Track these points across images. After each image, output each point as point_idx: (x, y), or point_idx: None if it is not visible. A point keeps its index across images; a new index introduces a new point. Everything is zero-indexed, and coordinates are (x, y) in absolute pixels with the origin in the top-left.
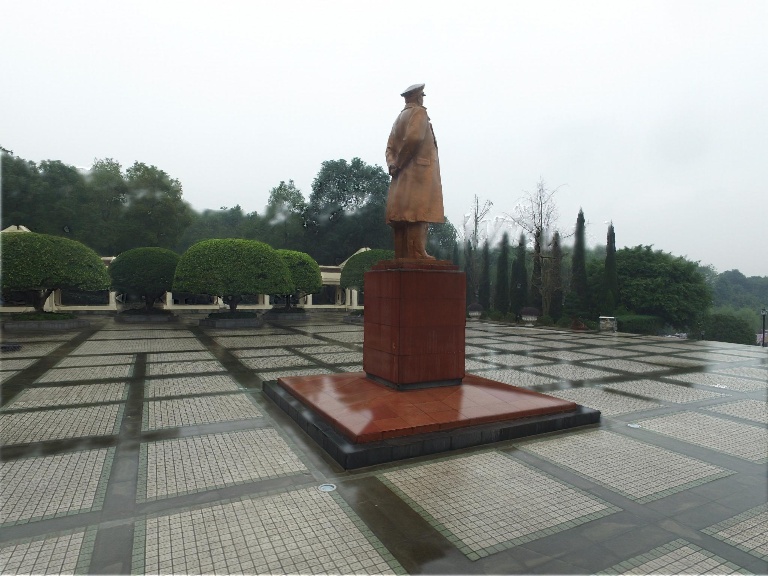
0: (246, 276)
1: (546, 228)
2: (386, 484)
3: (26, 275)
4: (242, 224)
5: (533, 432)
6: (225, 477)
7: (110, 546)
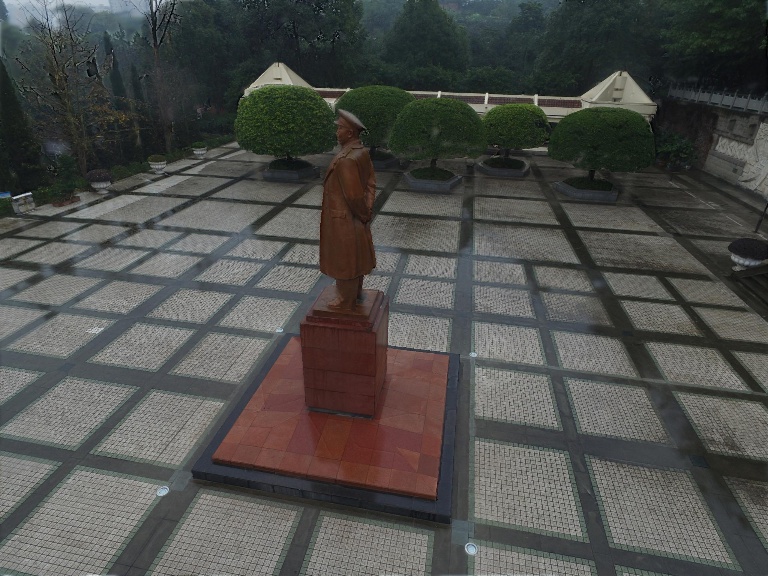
0: None
1: None
2: None
3: None
4: None
5: None
6: None
7: None
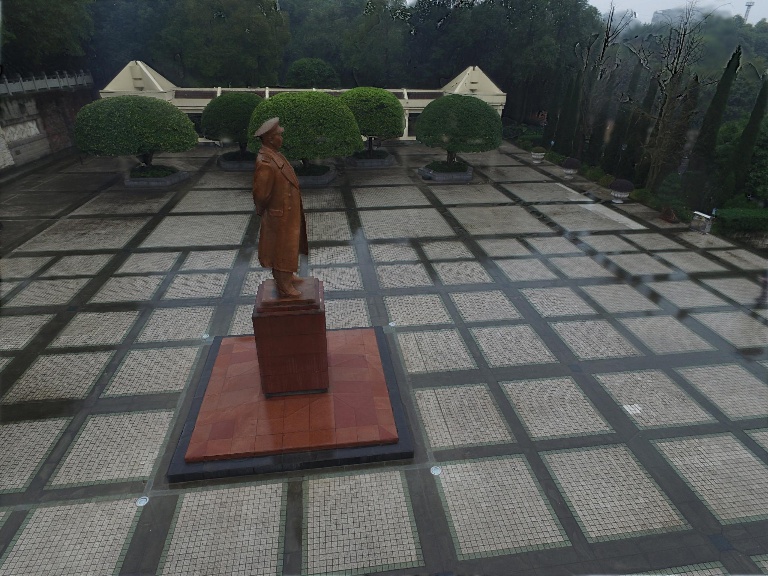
0: (305, 141)
1: (680, 72)
2: (177, 507)
3: (125, 144)
4: (342, 36)
5: (335, 464)
6: (101, 473)
7: (8, 529)
